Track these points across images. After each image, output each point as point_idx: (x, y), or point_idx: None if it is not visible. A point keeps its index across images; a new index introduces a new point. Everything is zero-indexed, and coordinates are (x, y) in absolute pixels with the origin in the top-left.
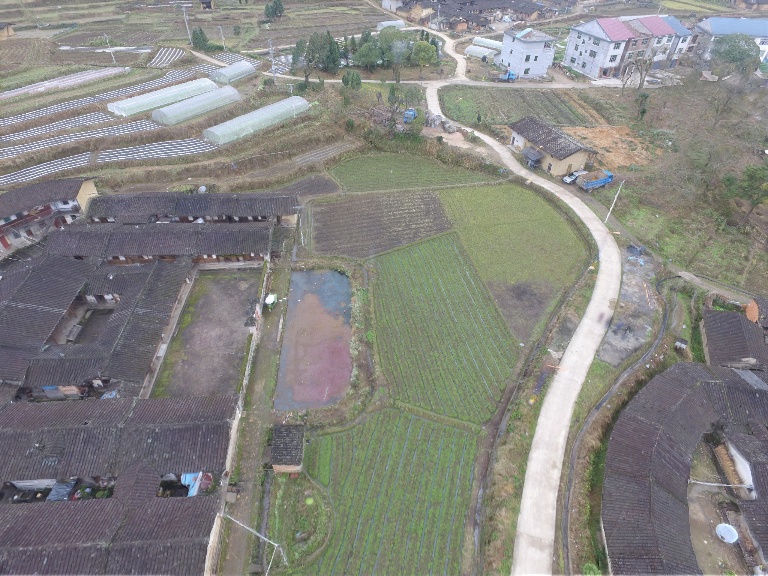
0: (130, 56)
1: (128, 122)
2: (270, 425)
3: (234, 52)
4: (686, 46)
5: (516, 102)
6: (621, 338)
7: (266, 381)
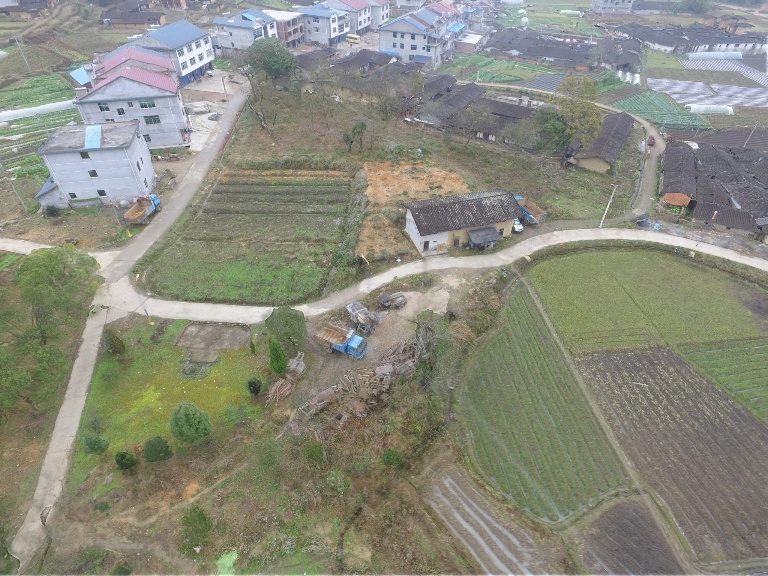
0: None
1: None
2: None
3: None
4: None
5: (247, 221)
6: None
7: None
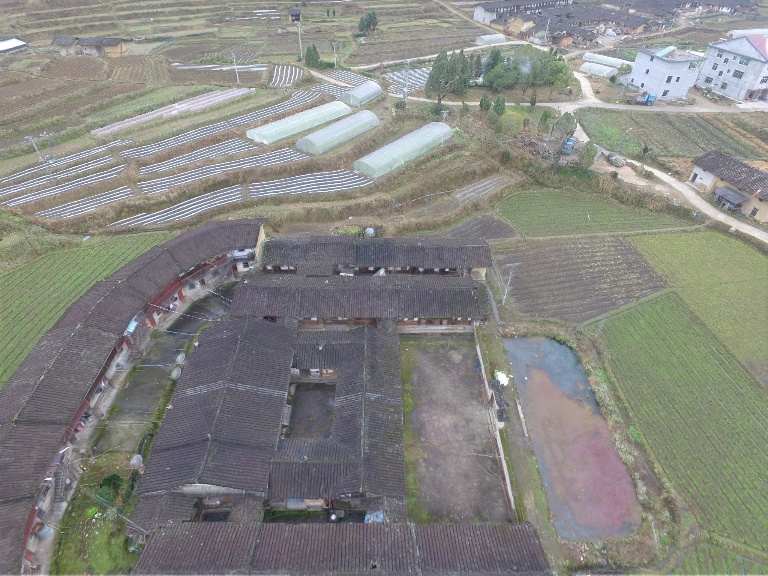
0: (249, 75)
1: (271, 151)
2: (566, 562)
3: (345, 69)
4: None
5: (666, 129)
6: None
7: (535, 494)
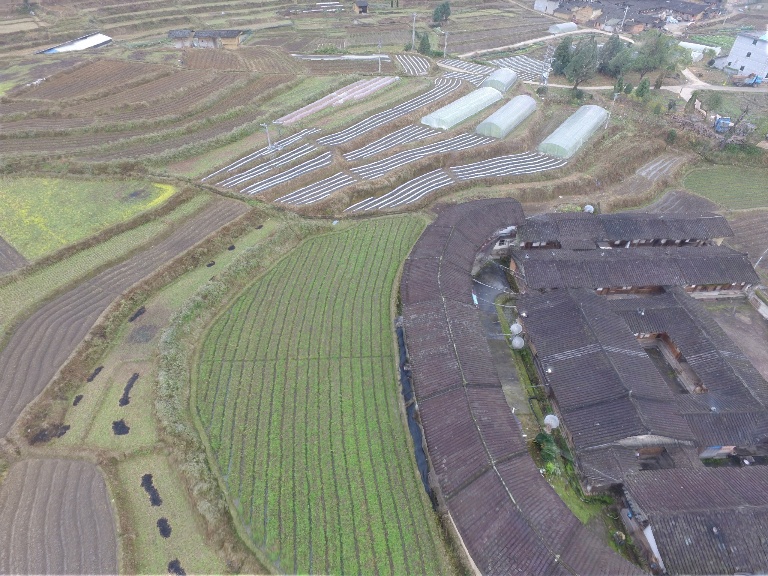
0: None
1: (454, 135)
2: None
3: (454, 58)
4: None
5: None
6: None
7: None
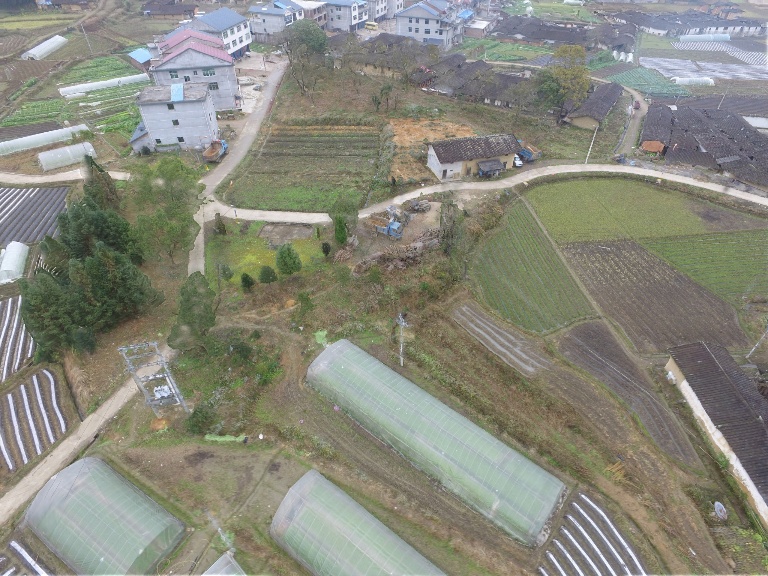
0: None
1: None
2: None
3: None
4: None
5: (299, 160)
6: (737, 186)
7: None
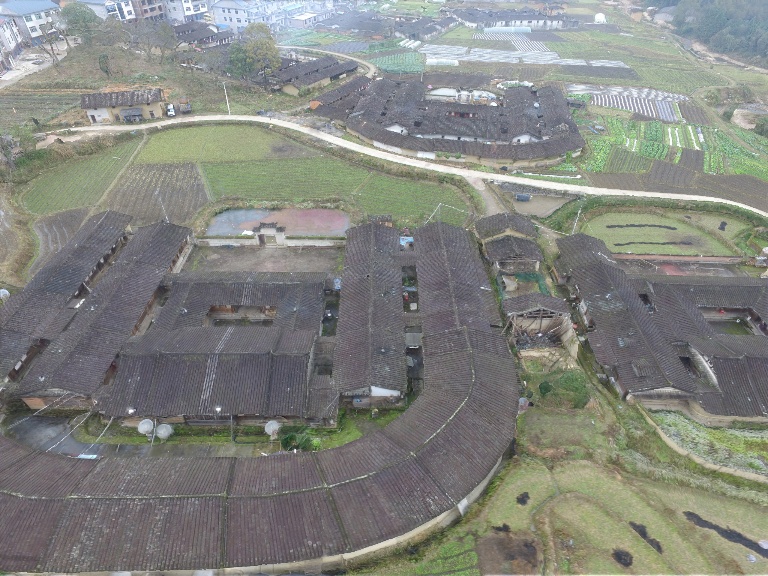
0: None
1: None
2: None
3: None
4: (16, 30)
5: None
6: (328, 129)
7: None
